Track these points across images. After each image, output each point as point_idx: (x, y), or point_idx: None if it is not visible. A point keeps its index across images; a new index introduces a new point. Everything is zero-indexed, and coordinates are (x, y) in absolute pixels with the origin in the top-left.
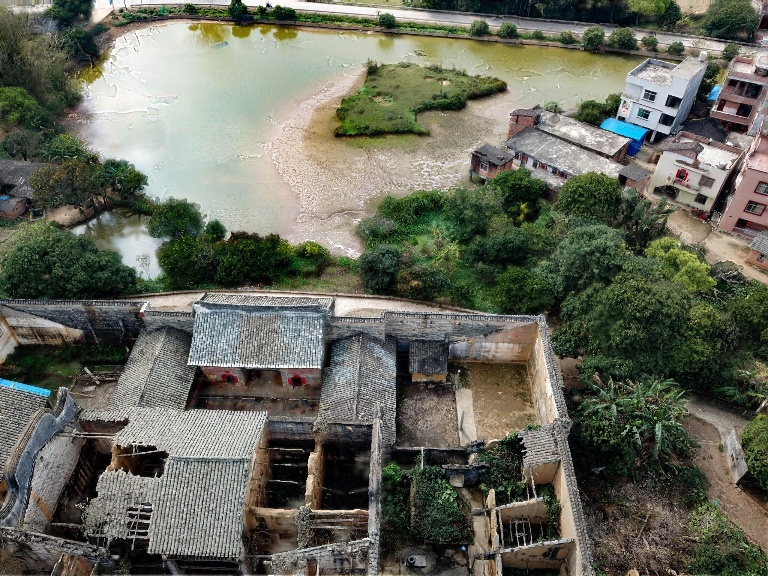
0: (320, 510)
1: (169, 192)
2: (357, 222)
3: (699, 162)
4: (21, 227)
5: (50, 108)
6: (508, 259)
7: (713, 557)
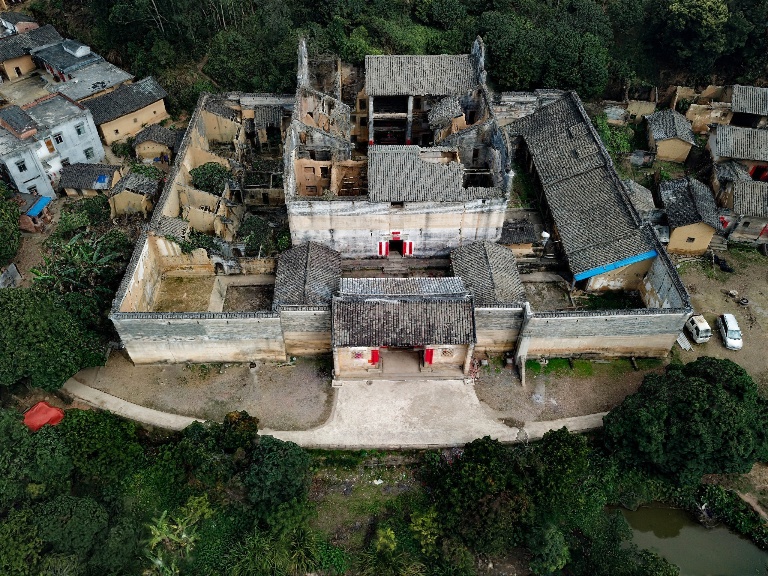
0: (326, 163)
1: None
2: None
3: None
4: None
5: None
6: None
7: (92, 201)
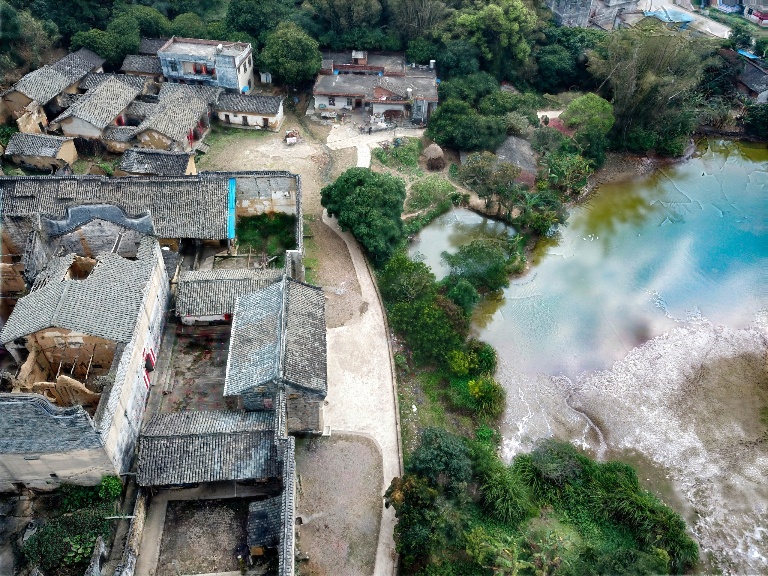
0: None
1: (556, 257)
2: (579, 443)
3: None
4: (433, 175)
5: (630, 140)
6: None
7: None
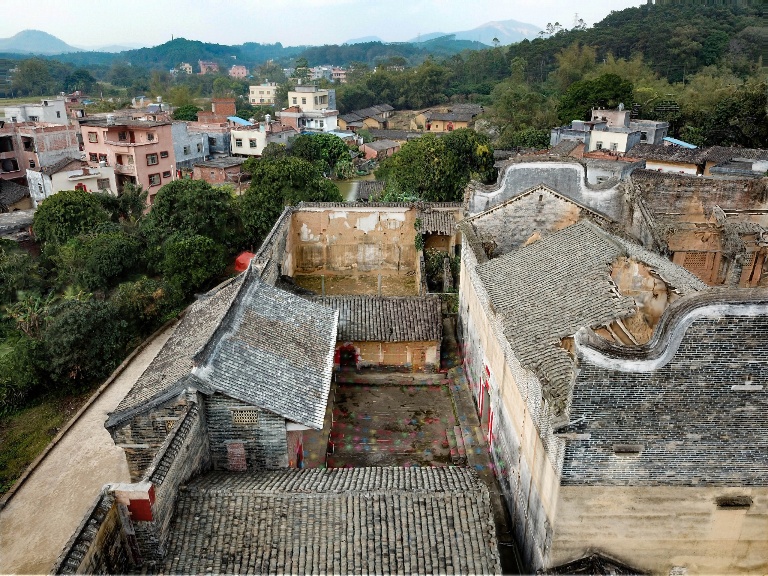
0: None
1: None
2: None
3: (87, 169)
4: None
5: None
6: (127, 271)
7: None
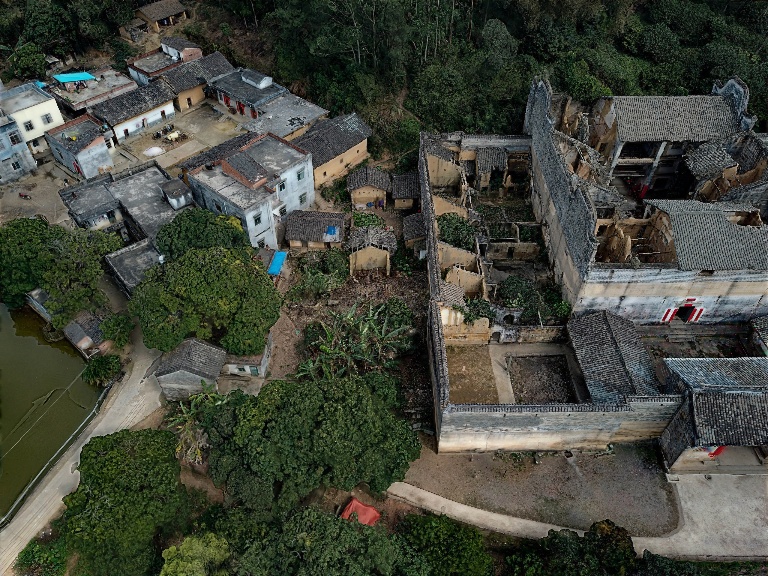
0: (607, 222)
1: None
2: None
3: None
4: None
5: None
6: None
7: None
